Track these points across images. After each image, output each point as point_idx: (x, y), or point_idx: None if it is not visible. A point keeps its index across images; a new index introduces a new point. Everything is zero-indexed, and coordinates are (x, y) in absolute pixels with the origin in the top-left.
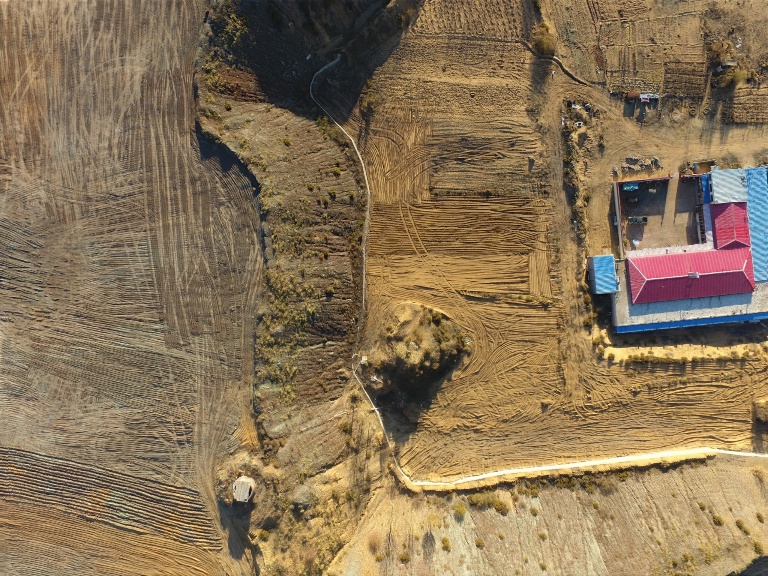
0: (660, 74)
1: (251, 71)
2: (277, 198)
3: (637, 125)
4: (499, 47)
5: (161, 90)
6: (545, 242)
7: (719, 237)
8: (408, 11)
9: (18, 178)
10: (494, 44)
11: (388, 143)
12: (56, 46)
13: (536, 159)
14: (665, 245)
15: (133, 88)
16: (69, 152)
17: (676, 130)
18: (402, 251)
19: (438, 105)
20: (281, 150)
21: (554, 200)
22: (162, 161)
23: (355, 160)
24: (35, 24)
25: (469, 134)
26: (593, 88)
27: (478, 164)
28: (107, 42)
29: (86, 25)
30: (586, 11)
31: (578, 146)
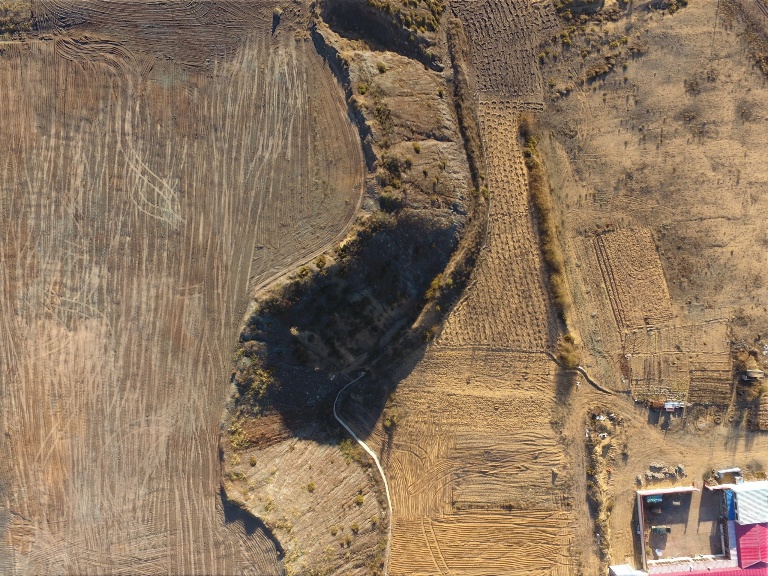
0: (685, 382)
1: (276, 412)
2: (301, 560)
3: (661, 432)
4: (524, 358)
5: (186, 452)
6: (567, 556)
7: (744, 557)
8: (433, 328)
9: (41, 540)
10: (519, 355)
11: (411, 456)
12: (82, 406)
13: (559, 471)
14: (688, 554)
15: (158, 450)
16: (93, 514)
17: (701, 438)
18: (423, 569)
19: (462, 418)
20: (305, 500)
21: (577, 512)
22: (186, 525)
23: (378, 480)
24: (61, 384)
25: (492, 447)
26: (618, 397)
27: (501, 477)
28: (133, 402)
29: (112, 384)
30: (612, 319)
31: (602, 456)
